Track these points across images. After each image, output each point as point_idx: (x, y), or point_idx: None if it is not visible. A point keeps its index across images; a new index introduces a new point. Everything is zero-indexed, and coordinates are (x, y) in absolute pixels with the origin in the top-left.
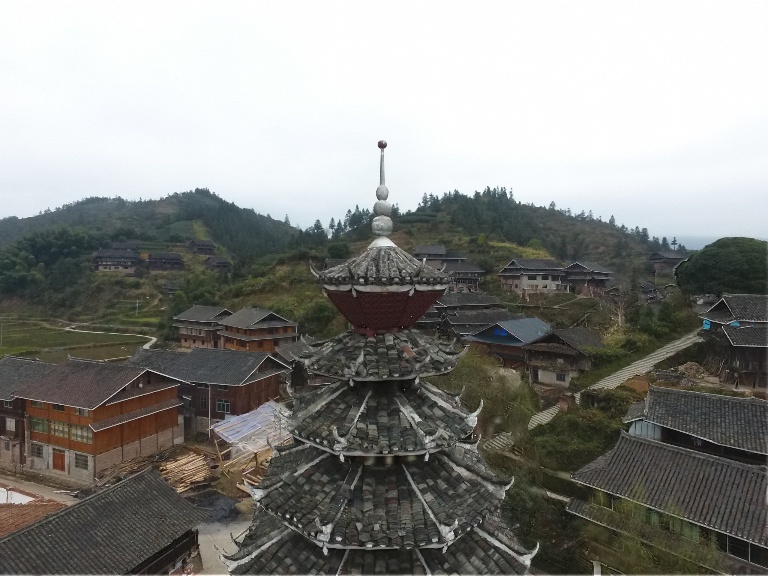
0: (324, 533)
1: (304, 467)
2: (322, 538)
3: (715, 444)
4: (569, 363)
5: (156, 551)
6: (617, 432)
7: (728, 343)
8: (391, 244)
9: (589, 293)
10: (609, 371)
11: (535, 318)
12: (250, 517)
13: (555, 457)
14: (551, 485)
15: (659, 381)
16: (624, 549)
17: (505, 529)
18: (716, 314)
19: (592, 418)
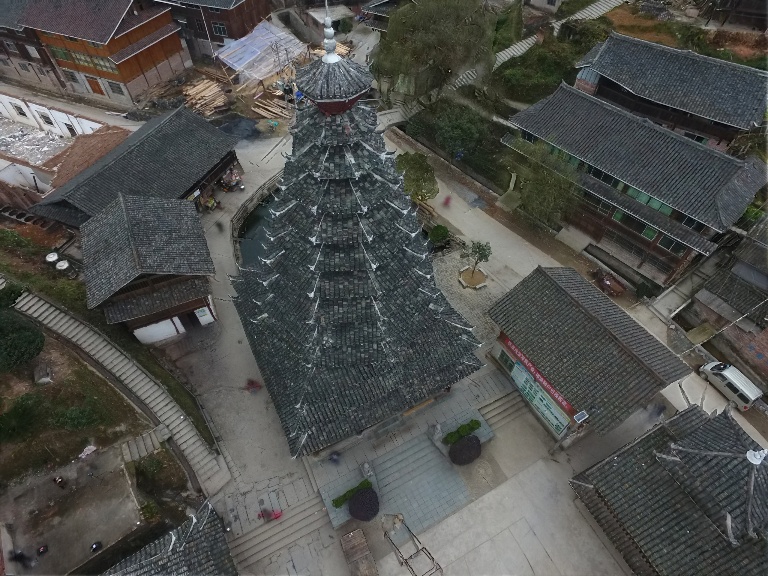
0: (314, 209)
1: (302, 175)
2: (313, 211)
3: (633, 94)
4: None
5: (212, 166)
6: (575, 69)
7: None
8: (336, 60)
9: None
10: None
11: None
12: (269, 136)
13: (517, 90)
14: (506, 114)
15: (640, 13)
16: (532, 168)
17: (403, 195)
18: None
19: (560, 53)
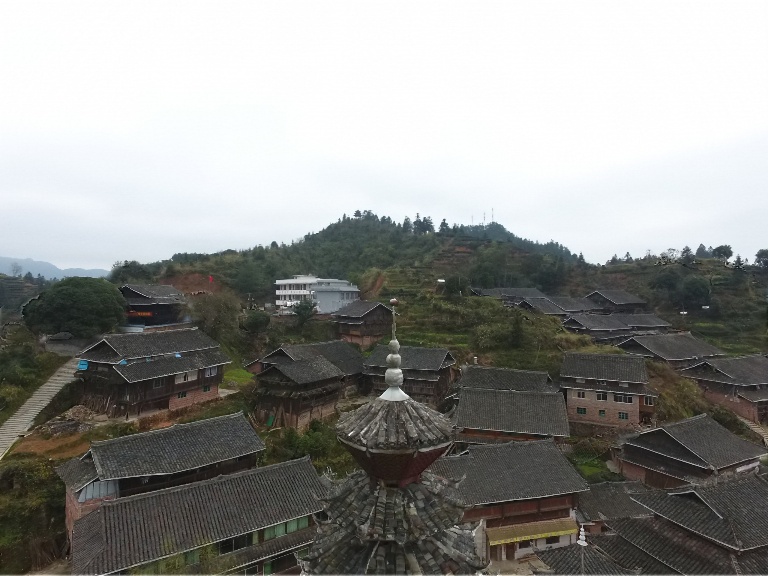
0: None
1: None
2: None
3: (168, 475)
4: None
5: None
6: (38, 509)
7: (123, 381)
8: None
9: None
10: None
11: None
12: None
13: None
14: None
15: (56, 435)
16: None
17: None
18: (97, 354)
19: None
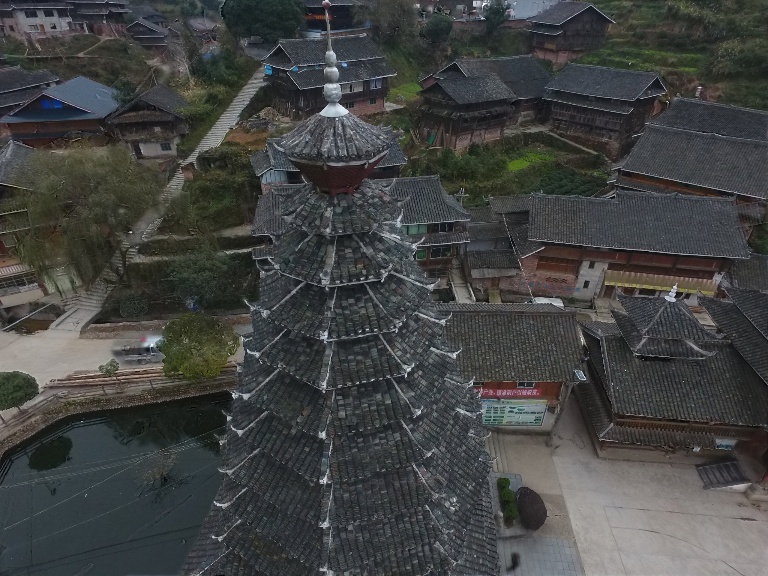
0: None
1: None
2: None
3: None
4: (169, 130)
5: None
6: (243, 184)
7: (296, 87)
8: None
9: (112, 32)
10: (205, 129)
11: (80, 77)
12: None
13: None
14: None
15: (253, 130)
16: None
17: None
18: (276, 60)
19: (218, 179)
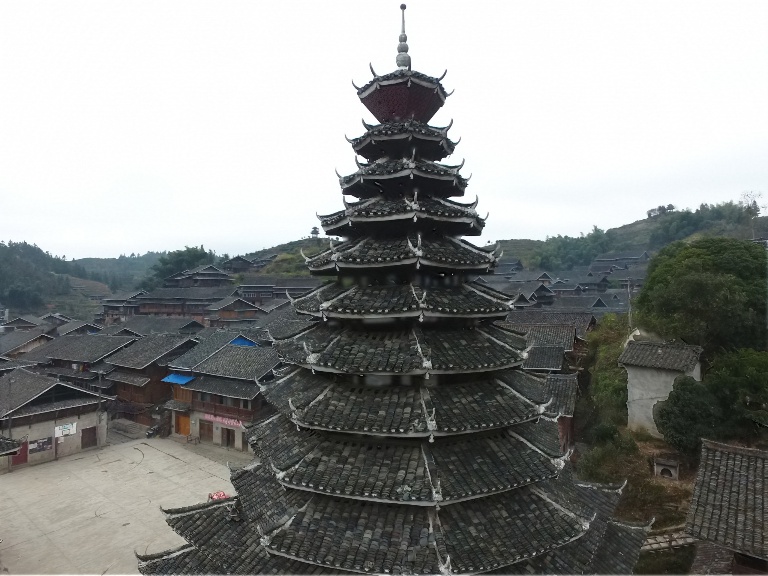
0: None
1: None
2: None
3: None
4: None
5: None
6: None
7: None
8: None
9: None
10: None
11: None
12: None
13: None
14: None
15: None
16: None
17: None
18: None
19: None
